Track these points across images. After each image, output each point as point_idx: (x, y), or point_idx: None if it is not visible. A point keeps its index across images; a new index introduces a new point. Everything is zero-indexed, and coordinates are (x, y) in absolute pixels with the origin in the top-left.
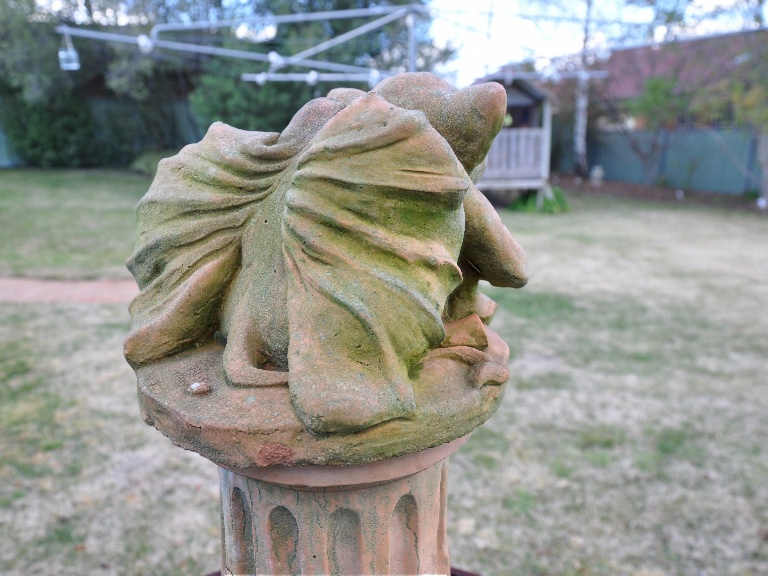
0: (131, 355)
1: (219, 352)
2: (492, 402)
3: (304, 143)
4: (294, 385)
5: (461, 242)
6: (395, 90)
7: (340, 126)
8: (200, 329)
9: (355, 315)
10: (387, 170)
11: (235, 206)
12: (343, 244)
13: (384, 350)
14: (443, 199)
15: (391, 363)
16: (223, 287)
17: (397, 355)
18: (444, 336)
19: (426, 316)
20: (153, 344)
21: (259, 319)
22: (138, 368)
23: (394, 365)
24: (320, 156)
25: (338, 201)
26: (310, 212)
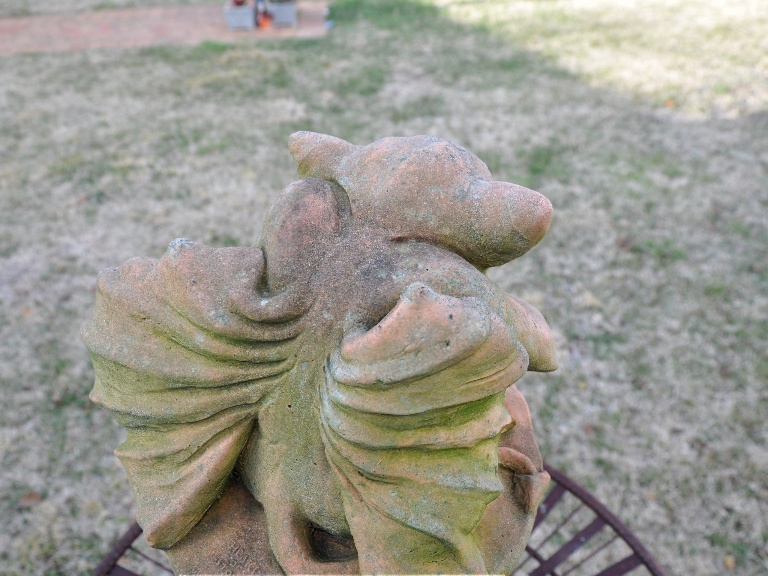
0: (157, 544)
1: (250, 509)
2: None
3: (312, 295)
4: None
5: None
6: (410, 198)
7: (390, 347)
8: None
9: (431, 536)
10: (452, 389)
11: (242, 382)
12: (403, 457)
13: (459, 549)
14: None
15: (464, 552)
16: None
17: (466, 535)
18: None
19: (491, 494)
20: (179, 529)
21: (303, 505)
22: (167, 550)
23: (466, 550)
24: (371, 387)
25: (397, 428)
26: (368, 447)
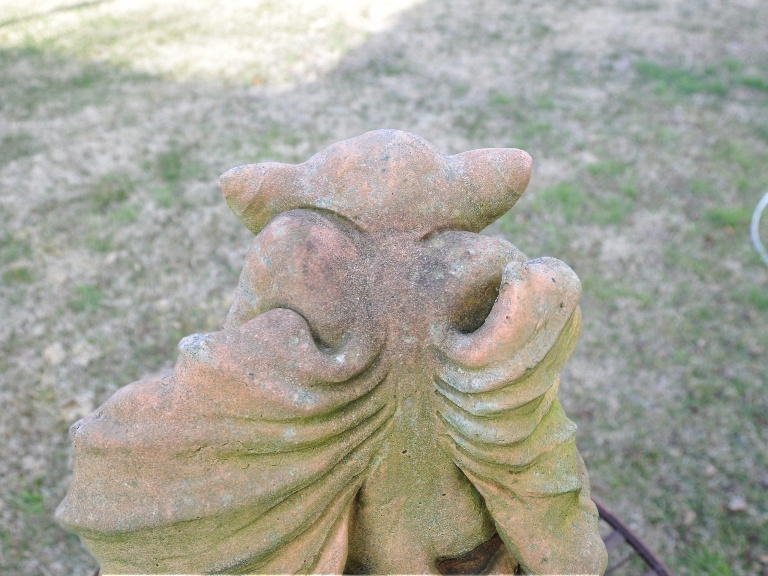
0: None
1: None
2: None
3: (382, 328)
4: None
5: None
6: (418, 193)
7: (524, 333)
8: None
9: None
10: (564, 347)
11: None
12: None
13: None
14: None
15: None
16: None
17: None
18: None
19: None
20: None
21: (436, 545)
22: None
23: None
24: None
25: None
26: None
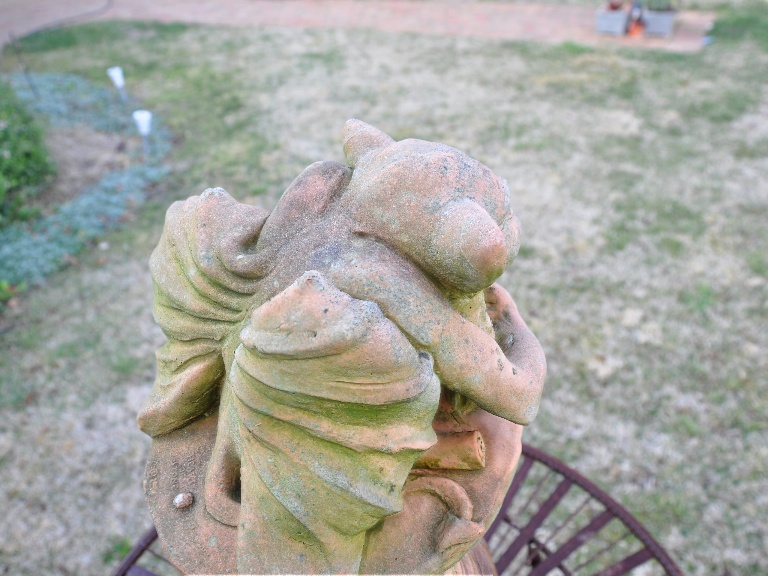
0: (144, 429)
1: None
2: (461, 553)
3: (275, 262)
4: (237, 560)
5: (434, 409)
6: (381, 198)
7: (271, 321)
8: (204, 408)
9: (290, 513)
10: (320, 380)
11: (213, 319)
12: (286, 430)
13: (323, 541)
14: (391, 404)
15: (332, 548)
16: (216, 381)
17: (343, 535)
18: None
19: (373, 507)
20: (160, 424)
21: None
22: (153, 438)
23: (337, 548)
24: (251, 351)
25: (273, 398)
26: (246, 405)
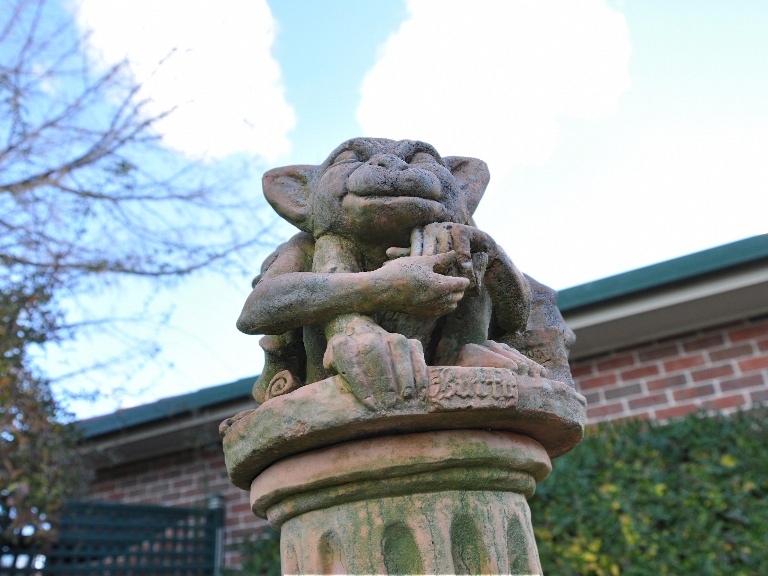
0: None
1: None
2: None
3: None
4: None
5: None
6: None
7: None
8: None
9: None
10: None
11: None
12: None
13: None
14: None
15: None
16: None
17: None
18: (256, 399)
19: None
20: None
21: None
22: None
23: None
24: None
25: None
26: None
